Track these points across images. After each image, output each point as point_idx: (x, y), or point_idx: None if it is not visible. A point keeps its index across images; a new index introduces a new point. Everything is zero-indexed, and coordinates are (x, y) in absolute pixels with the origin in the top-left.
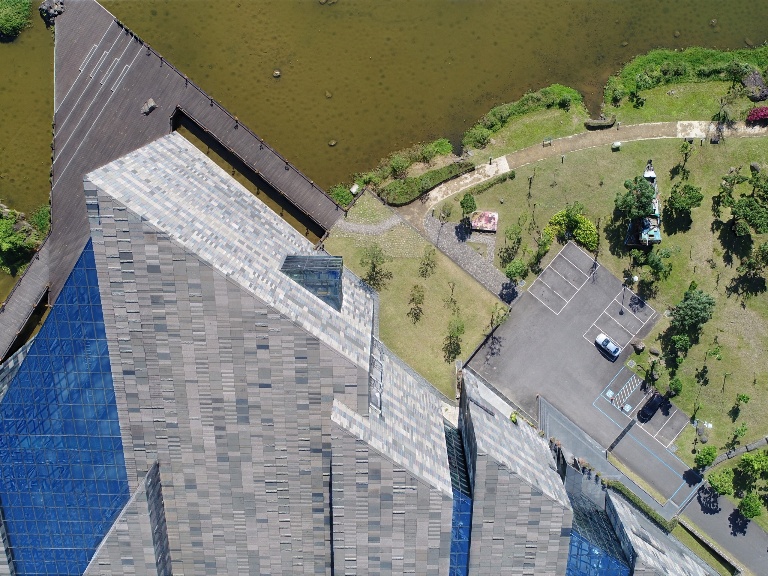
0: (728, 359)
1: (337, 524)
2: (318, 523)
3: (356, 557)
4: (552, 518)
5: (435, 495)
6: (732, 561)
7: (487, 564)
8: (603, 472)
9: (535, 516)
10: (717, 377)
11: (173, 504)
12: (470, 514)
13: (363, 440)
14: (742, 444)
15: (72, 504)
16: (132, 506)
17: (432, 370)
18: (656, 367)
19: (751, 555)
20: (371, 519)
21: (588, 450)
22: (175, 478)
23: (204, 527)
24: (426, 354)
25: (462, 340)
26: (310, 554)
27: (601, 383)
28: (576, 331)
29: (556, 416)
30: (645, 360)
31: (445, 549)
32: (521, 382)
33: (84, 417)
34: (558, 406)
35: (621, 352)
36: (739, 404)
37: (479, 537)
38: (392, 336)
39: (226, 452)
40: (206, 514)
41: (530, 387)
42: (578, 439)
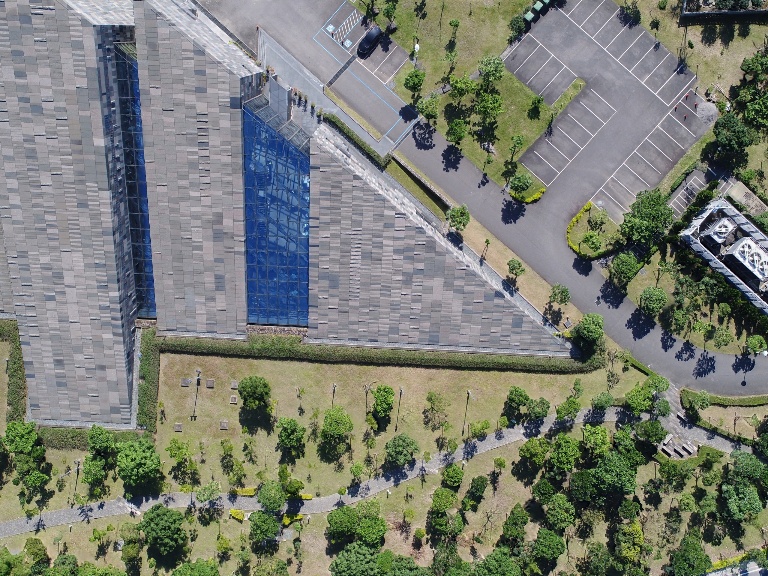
0: None
1: None
2: None
3: (5, 97)
4: (219, 84)
5: (74, 18)
6: (443, 196)
7: (161, 142)
8: (319, 105)
9: (201, 81)
10: (435, 10)
11: None
12: None
13: None
14: (457, 77)
15: None
16: None
17: None
18: None
19: (462, 191)
20: (14, 48)
21: (305, 82)
22: None
23: None
24: None
25: None
26: None
27: (322, 17)
28: None
29: (274, 47)
30: None
31: (94, 90)
32: (242, 13)
33: None
34: (278, 39)
35: None
36: (455, 37)
37: (149, 107)
38: None
39: None
40: None
41: (251, 18)
42: (295, 70)
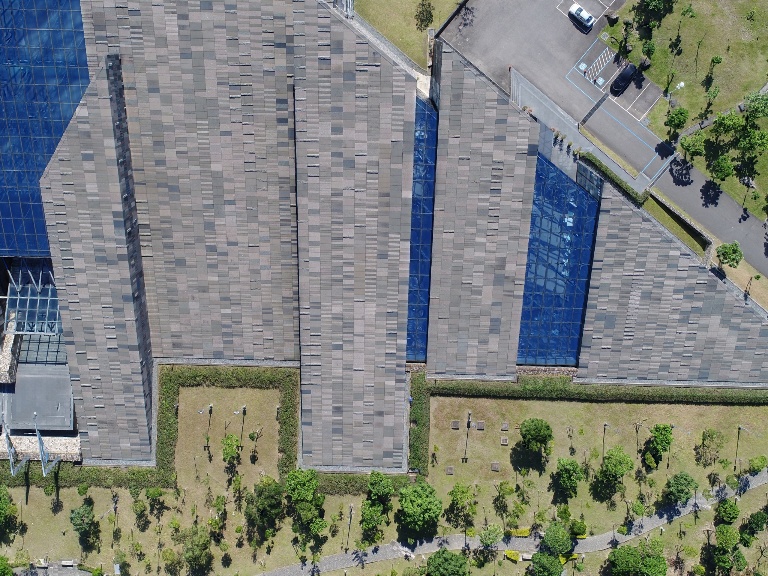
0: (702, 27)
1: (299, 110)
2: (282, 137)
3: (319, 153)
4: (518, 132)
5: (398, 74)
6: (703, 231)
7: (453, 190)
8: (575, 144)
9: (501, 130)
10: (691, 46)
11: (136, 112)
12: (436, 131)
13: (325, 3)
14: None
15: (34, 116)
16: (92, 86)
17: (404, 38)
18: (629, 31)
19: (723, 226)
20: (334, 104)
21: (560, 121)
22: (138, 79)
23: (167, 141)
24: (398, 22)
25: (435, 8)
26: (274, 176)
27: (574, 55)
28: (550, 2)
29: (528, 87)
30: (619, 31)
31: (409, 143)
32: (494, 54)
33: (46, 6)
34: (530, 78)
35: (595, 24)
36: (712, 73)
37: (445, 156)
38: (364, 3)
39: (189, 47)
40: (169, 125)
41: (503, 59)
42: (550, 110)
